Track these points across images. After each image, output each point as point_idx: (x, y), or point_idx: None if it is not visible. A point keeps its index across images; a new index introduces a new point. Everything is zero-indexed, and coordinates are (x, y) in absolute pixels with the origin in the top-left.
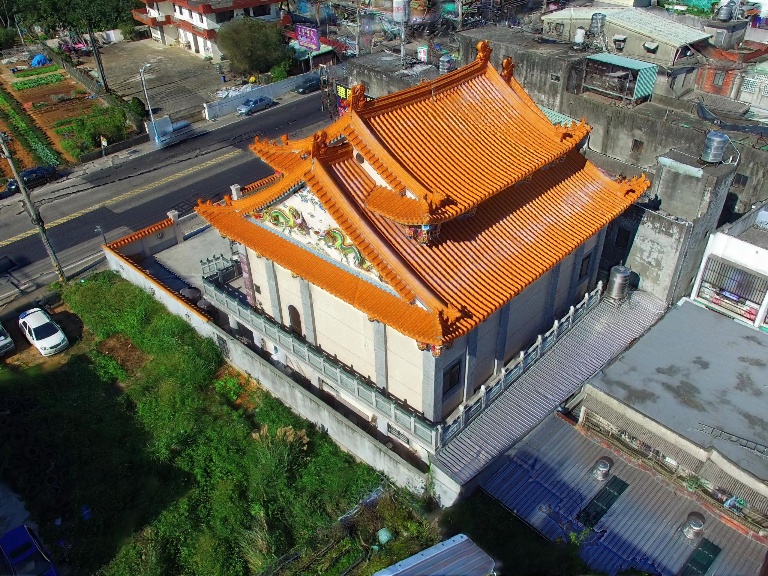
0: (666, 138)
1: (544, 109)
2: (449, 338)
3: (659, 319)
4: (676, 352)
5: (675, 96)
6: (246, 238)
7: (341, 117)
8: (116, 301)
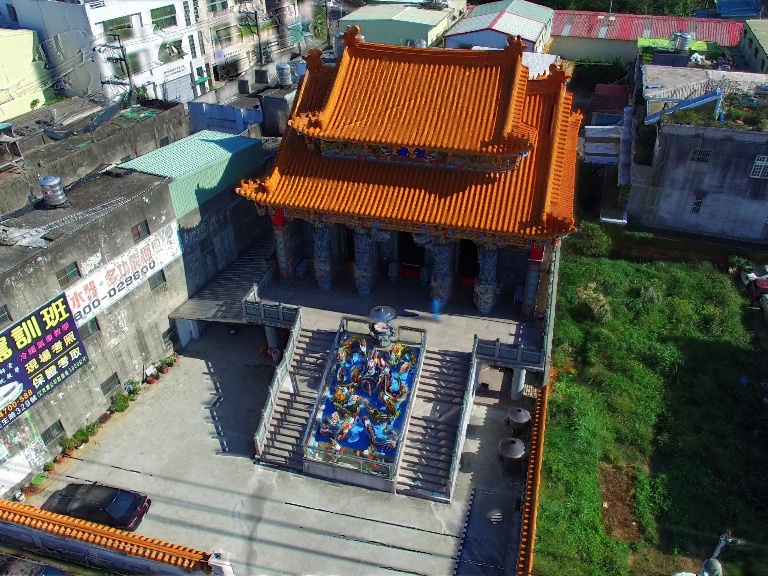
0: (106, 155)
1: (168, 147)
2: None
3: None
4: None
5: (18, 140)
6: (569, 205)
7: (518, 67)
8: (575, 570)
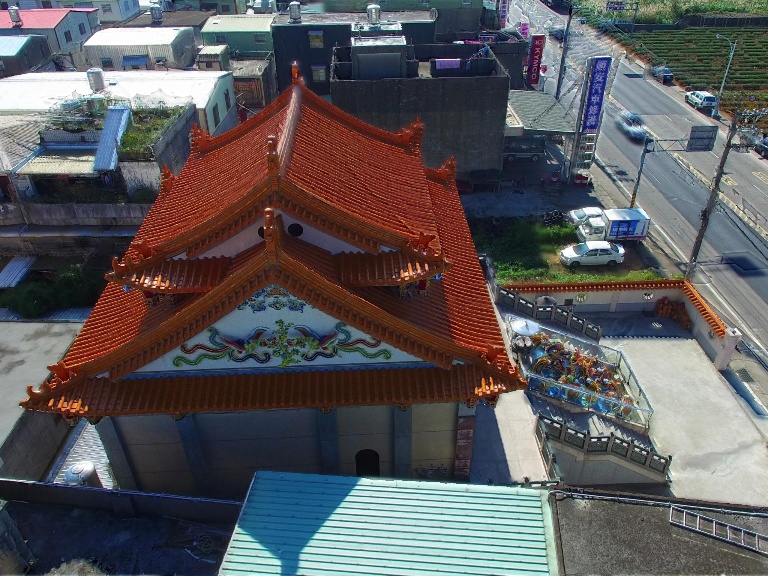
0: None
1: None
2: (163, 179)
3: (22, 417)
4: (4, 388)
5: None
6: None
7: None
8: None
